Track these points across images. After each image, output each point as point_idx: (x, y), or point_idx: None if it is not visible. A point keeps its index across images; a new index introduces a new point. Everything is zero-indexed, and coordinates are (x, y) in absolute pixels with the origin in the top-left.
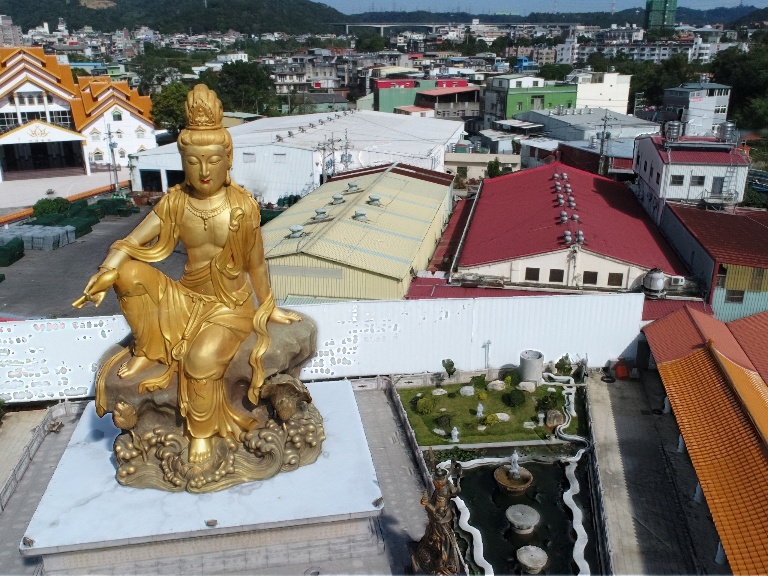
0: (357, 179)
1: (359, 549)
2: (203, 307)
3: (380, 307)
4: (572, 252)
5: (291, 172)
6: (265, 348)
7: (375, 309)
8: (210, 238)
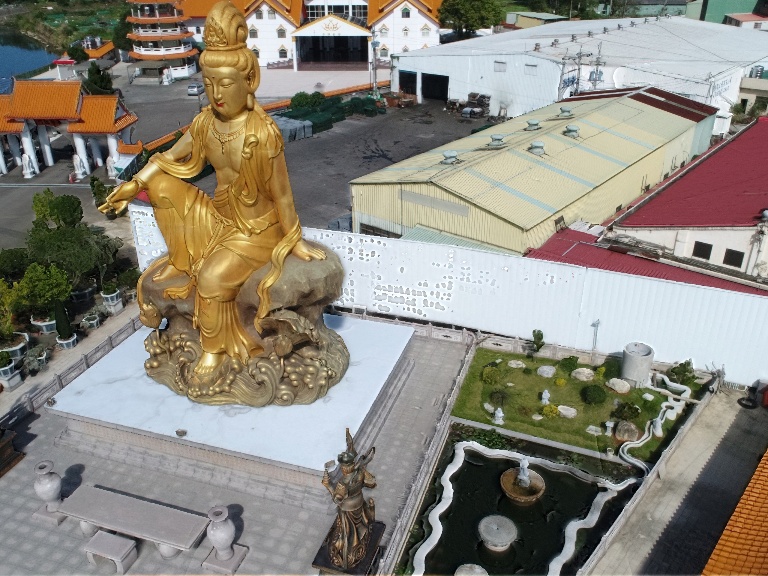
0: (585, 102)
1: (311, 502)
2: (223, 229)
3: (478, 257)
4: (758, 232)
5: (540, 86)
6: (273, 281)
7: (472, 258)
8: (228, 162)
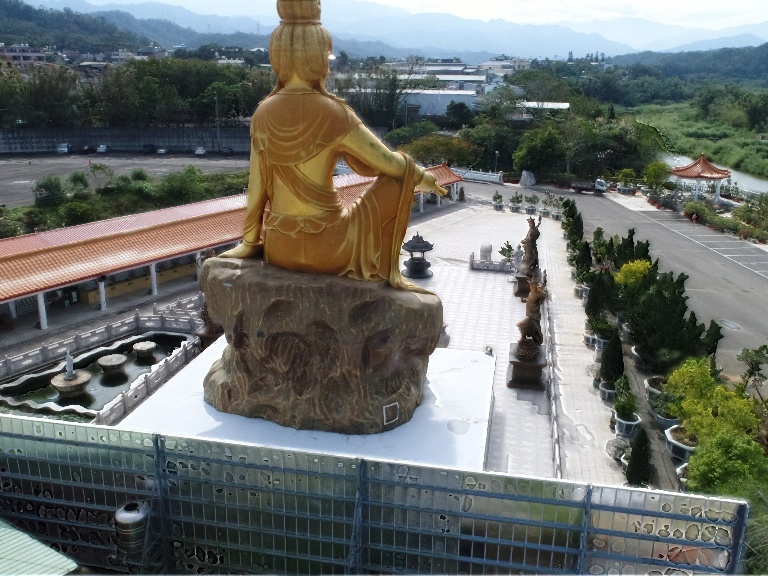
0: None
1: None
2: None
3: None
4: None
5: None
6: None
7: None
8: None
